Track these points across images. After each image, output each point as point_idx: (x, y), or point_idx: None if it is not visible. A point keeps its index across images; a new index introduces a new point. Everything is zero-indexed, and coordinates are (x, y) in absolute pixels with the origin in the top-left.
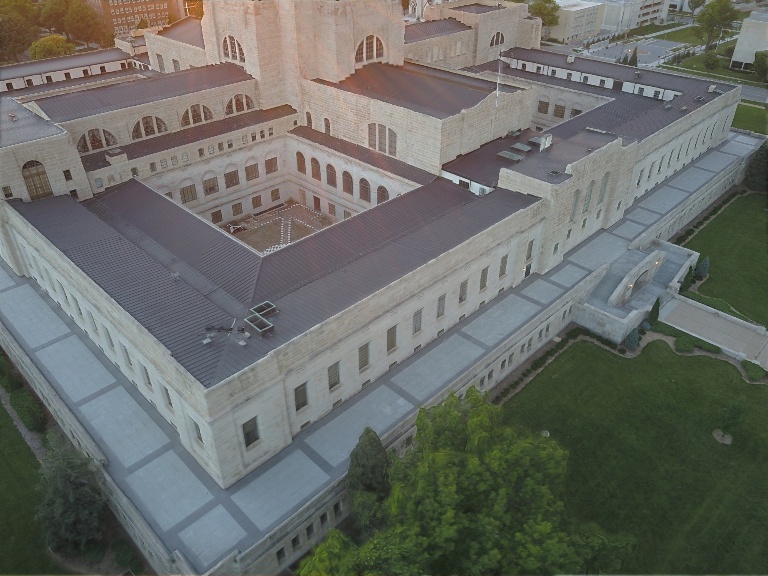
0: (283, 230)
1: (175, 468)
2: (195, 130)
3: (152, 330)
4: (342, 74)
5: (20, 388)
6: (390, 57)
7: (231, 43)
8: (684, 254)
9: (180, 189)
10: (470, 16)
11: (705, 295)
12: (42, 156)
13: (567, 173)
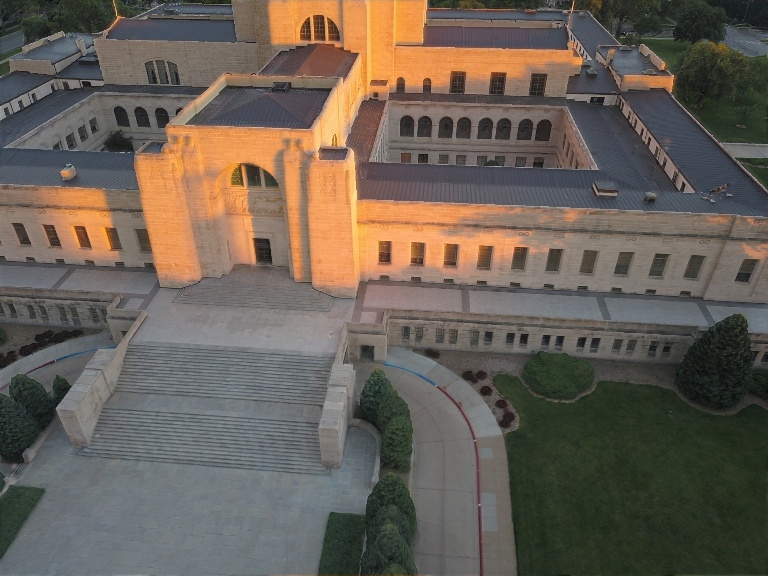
0: None
1: None
2: None
3: (200, 6)
4: None
5: None
6: None
7: None
8: None
9: None
10: (243, 79)
11: None
12: None
13: None
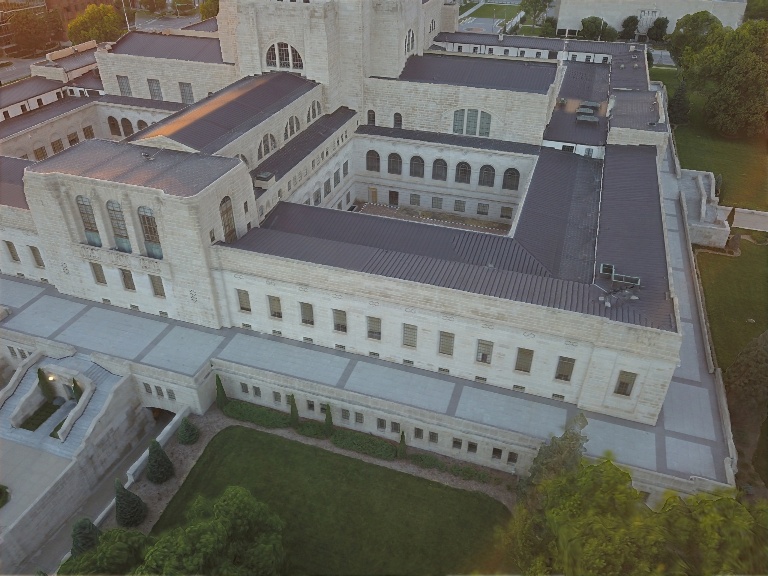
0: None
1: (600, 427)
2: (294, 143)
3: None
4: (400, 69)
5: (336, 430)
6: (418, 49)
7: (279, 50)
8: (702, 176)
9: None
10: None
11: (732, 202)
12: (232, 190)
13: (661, 123)
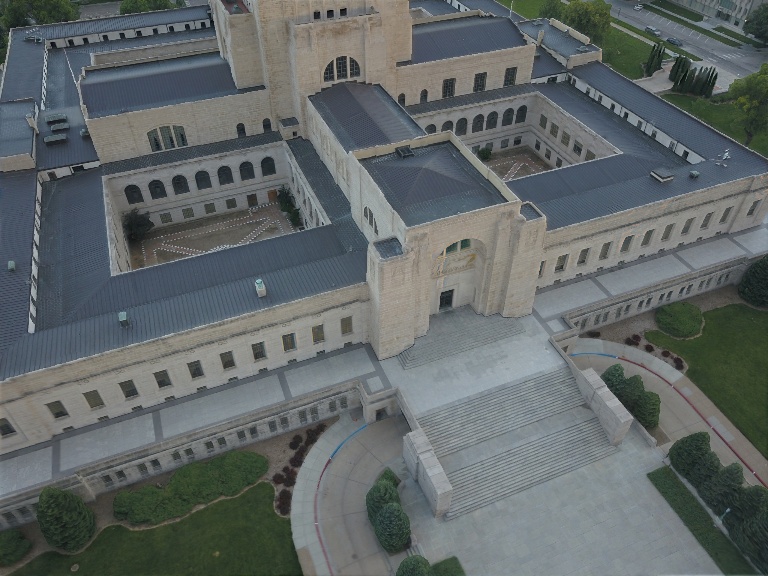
0: None
1: None
2: None
3: (59, 26)
4: None
5: None
6: None
7: None
8: None
9: None
10: None
11: None
12: None
13: None
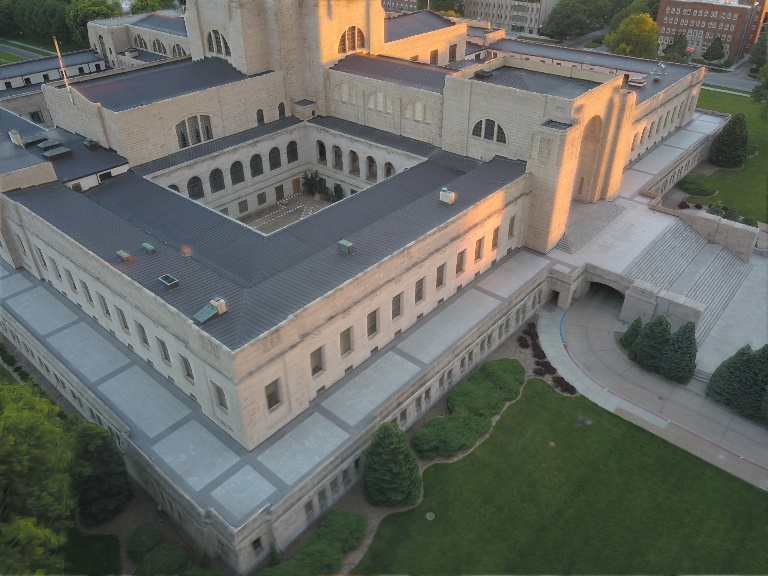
0: None
1: None
2: None
3: None
4: (194, 55)
5: None
6: (233, 59)
7: None
8: None
9: None
10: None
11: None
12: None
13: None
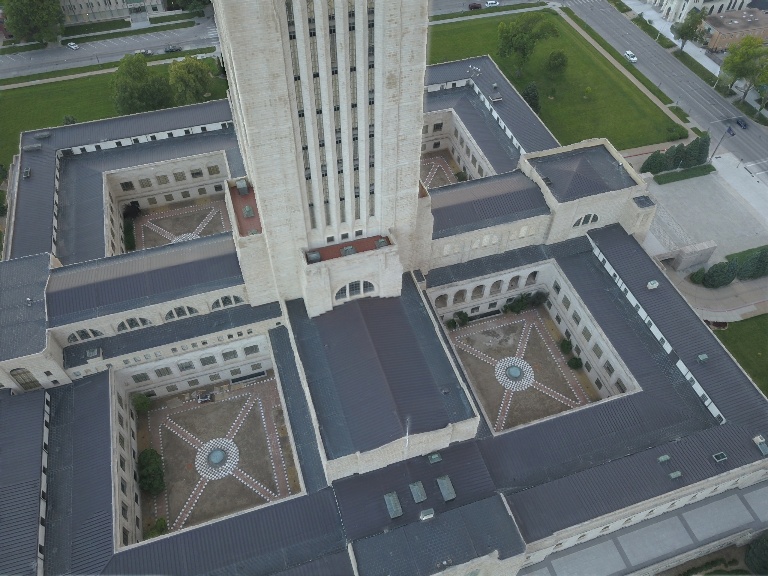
0: (239, 416)
1: None
2: (178, 324)
3: None
4: (316, 312)
5: None
6: (381, 293)
7: None
8: None
9: (156, 370)
10: (551, 199)
11: None
12: (25, 366)
13: None
